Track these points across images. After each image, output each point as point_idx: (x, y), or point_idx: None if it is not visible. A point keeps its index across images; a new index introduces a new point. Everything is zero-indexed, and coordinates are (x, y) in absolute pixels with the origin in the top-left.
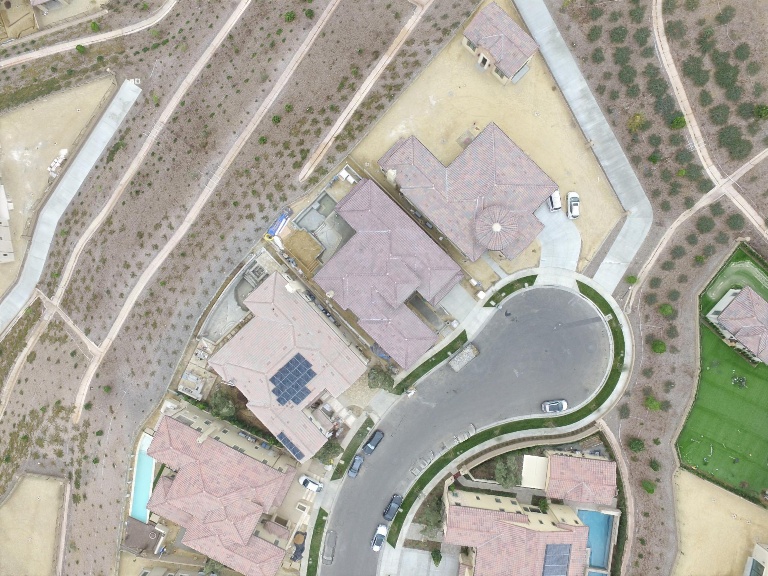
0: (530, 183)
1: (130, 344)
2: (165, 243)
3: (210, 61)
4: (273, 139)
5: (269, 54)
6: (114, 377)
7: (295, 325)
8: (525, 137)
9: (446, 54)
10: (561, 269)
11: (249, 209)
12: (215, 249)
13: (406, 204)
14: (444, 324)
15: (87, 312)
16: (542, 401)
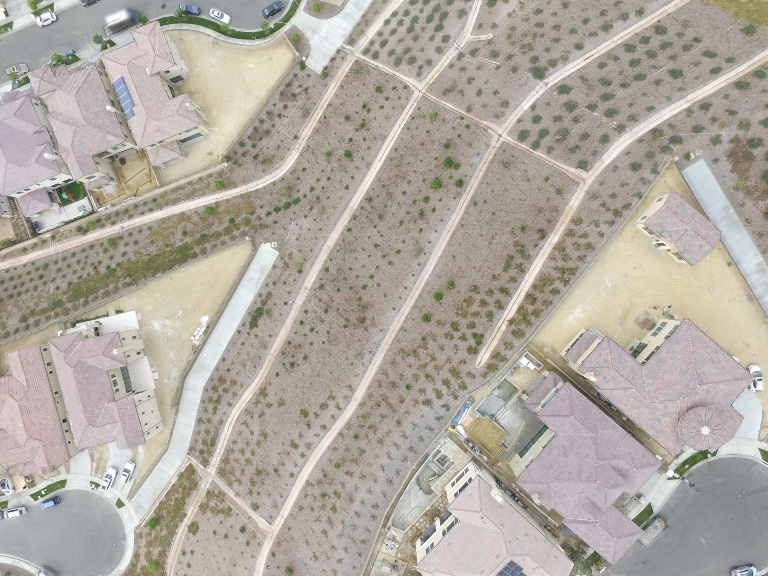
0: (729, 378)
1: (307, 525)
2: (333, 423)
3: (350, 224)
4: (438, 318)
5: (419, 224)
6: (293, 559)
7: (504, 532)
8: (702, 313)
9: (619, 236)
10: (743, 438)
11: (424, 394)
12: (392, 435)
13: (589, 388)
14: (630, 499)
15: (251, 487)
16: (730, 567)
